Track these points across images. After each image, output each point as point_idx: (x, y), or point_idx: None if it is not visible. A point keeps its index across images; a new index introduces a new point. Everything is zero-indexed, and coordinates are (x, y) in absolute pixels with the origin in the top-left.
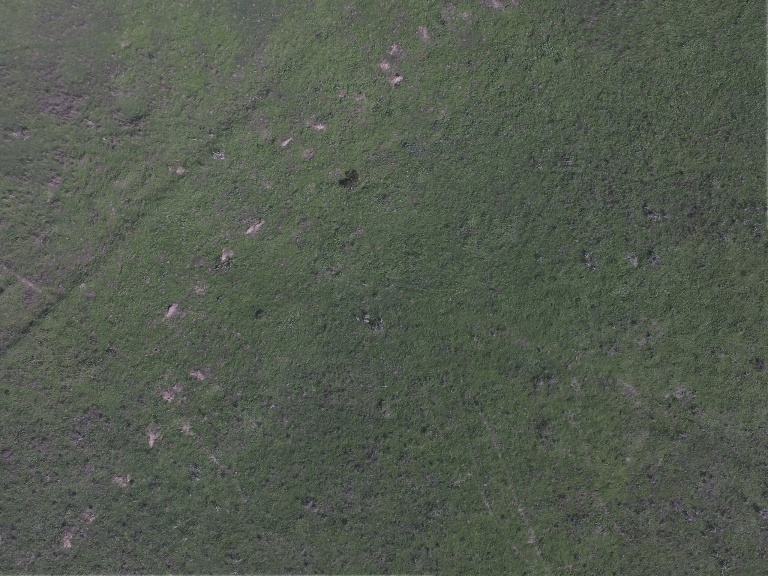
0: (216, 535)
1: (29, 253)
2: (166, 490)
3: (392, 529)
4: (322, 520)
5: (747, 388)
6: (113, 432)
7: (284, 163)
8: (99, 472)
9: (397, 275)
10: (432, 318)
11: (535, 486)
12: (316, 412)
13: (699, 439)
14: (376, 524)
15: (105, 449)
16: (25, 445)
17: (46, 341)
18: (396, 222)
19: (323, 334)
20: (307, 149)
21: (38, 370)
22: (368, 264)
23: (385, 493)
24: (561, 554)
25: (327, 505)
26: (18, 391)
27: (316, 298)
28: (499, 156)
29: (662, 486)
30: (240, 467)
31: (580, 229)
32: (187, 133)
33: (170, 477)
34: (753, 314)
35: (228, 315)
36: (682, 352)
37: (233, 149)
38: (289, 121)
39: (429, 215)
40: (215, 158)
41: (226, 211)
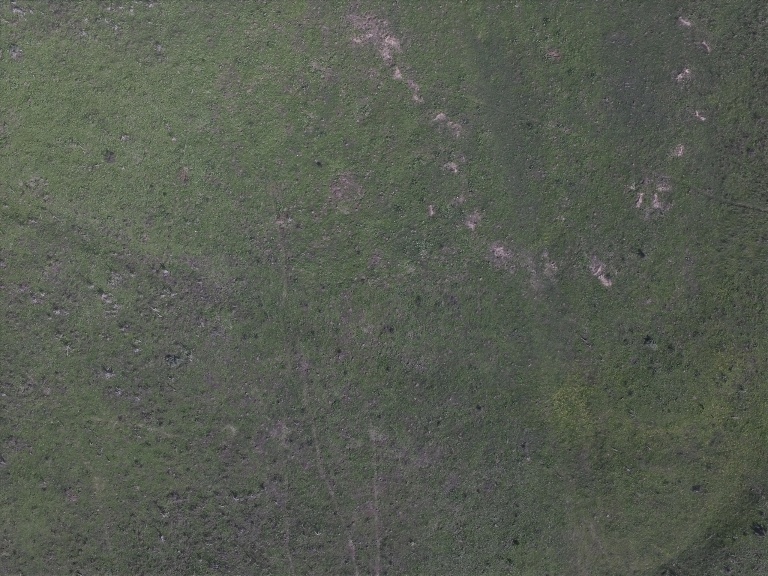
0: None
1: None
2: None
3: None
4: None
5: (98, 178)
6: None
7: None
8: None
9: None
10: None
11: None
12: None
13: (50, 226)
14: None
15: None
16: None
17: None
18: None
19: None
20: None
21: None
22: None
23: None
24: None
25: None
26: None
27: None
28: None
29: (12, 269)
30: None
31: None
32: None
33: None
34: (107, 108)
35: None
36: (36, 142)
37: None
38: None
39: None
40: None
41: None
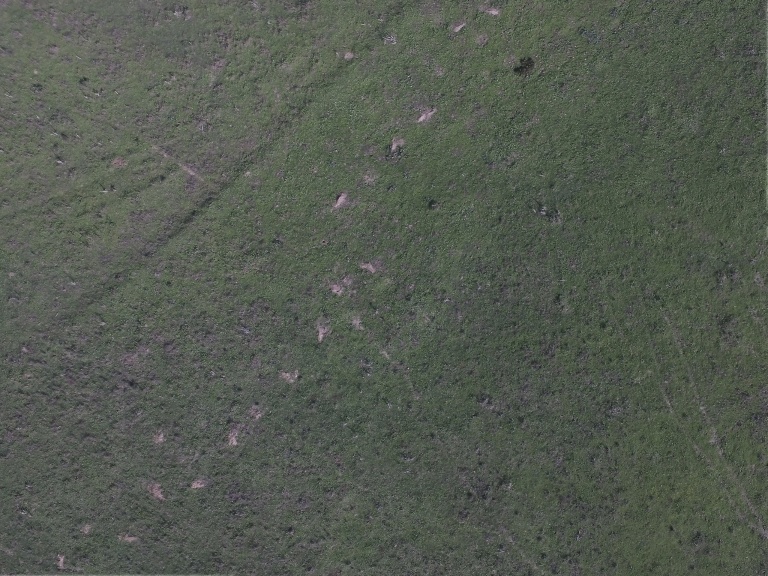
0: (387, 433)
1: (190, 141)
2: (335, 386)
3: (569, 427)
4: (497, 418)
5: None
6: (280, 326)
7: (458, 49)
8: (266, 367)
9: (574, 166)
10: (611, 211)
11: (717, 383)
12: (491, 307)
13: None
14: (553, 422)
15: (272, 344)
16: (188, 339)
17: (210, 231)
18: (573, 112)
19: (498, 226)
20: (481, 35)
21: (201, 262)
22: (545, 155)
23: (563, 390)
24: (744, 453)
25: (502, 402)
26: (181, 283)
27: (490, 189)
28: (680, 45)
29: None
30: (412, 363)
31: (764, 120)
32: (355, 18)
33: (339, 373)
34: None
35: (399, 206)
36: None
37: (406, 33)
38: (462, 6)
39: (607, 105)
40: (386, 43)
41: (396, 99)
